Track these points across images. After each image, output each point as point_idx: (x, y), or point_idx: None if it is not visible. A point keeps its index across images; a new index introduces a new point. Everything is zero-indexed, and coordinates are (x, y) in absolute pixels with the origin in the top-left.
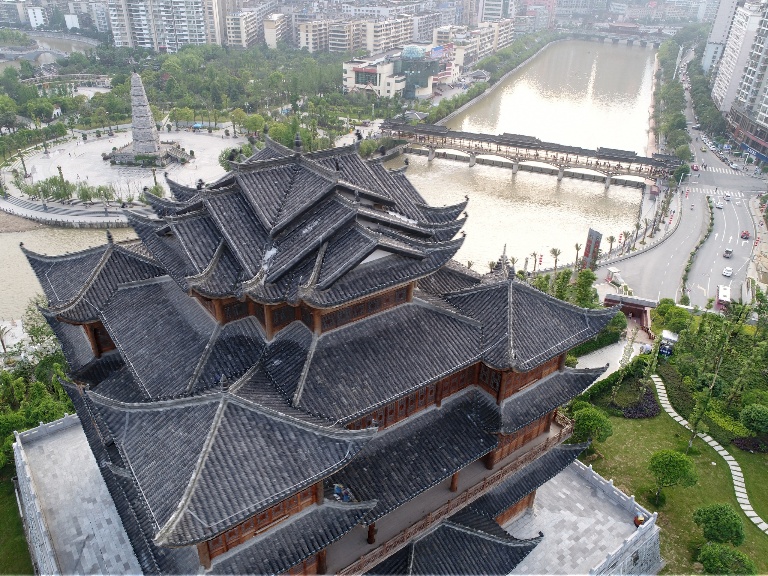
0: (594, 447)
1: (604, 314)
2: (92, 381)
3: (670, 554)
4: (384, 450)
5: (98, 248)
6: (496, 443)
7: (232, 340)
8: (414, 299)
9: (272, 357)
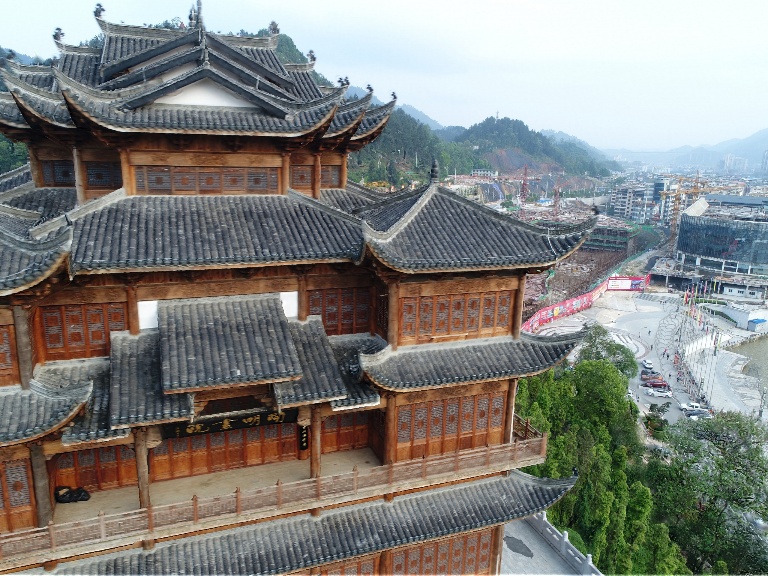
0: None
1: None
2: None
3: None
4: None
5: None
6: None
7: None
8: None
9: None
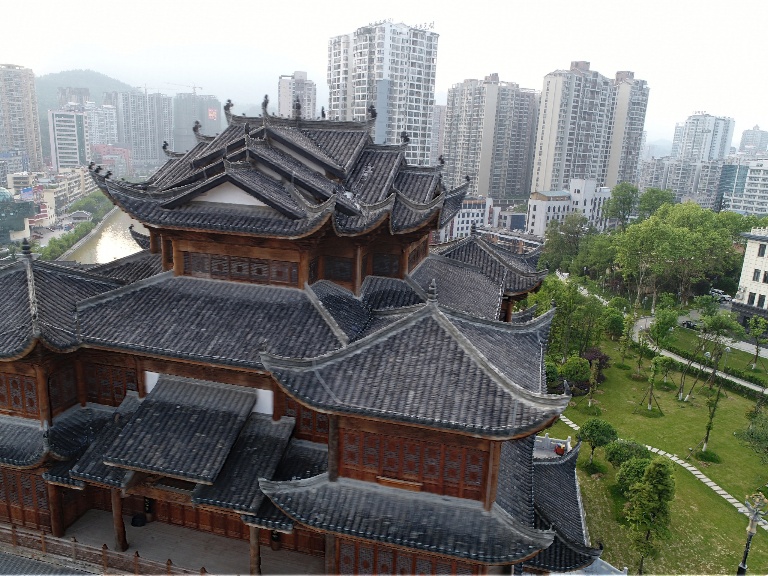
0: None
1: (533, 255)
2: (68, 452)
3: None
4: None
5: (2, 271)
6: None
7: (329, 299)
8: (430, 253)
9: (379, 306)
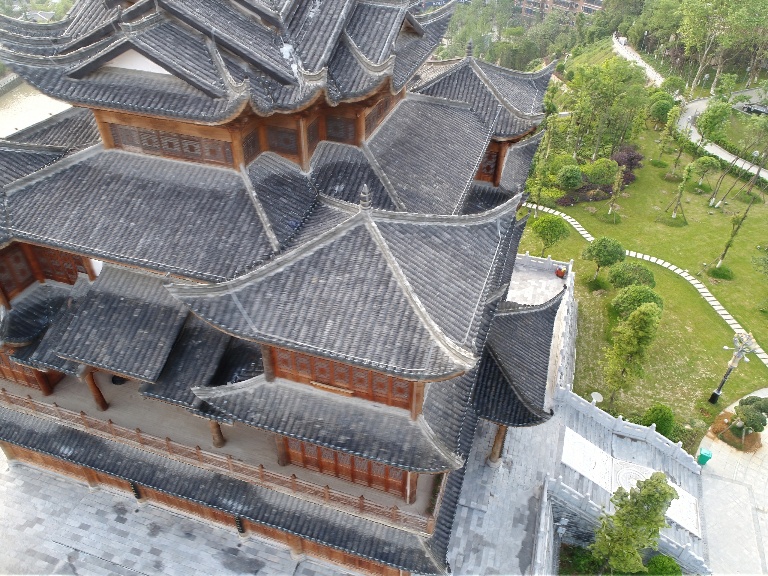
0: None
1: (544, 74)
2: (27, 338)
3: (576, 294)
4: None
5: None
6: None
7: (269, 182)
8: (407, 93)
9: (327, 185)
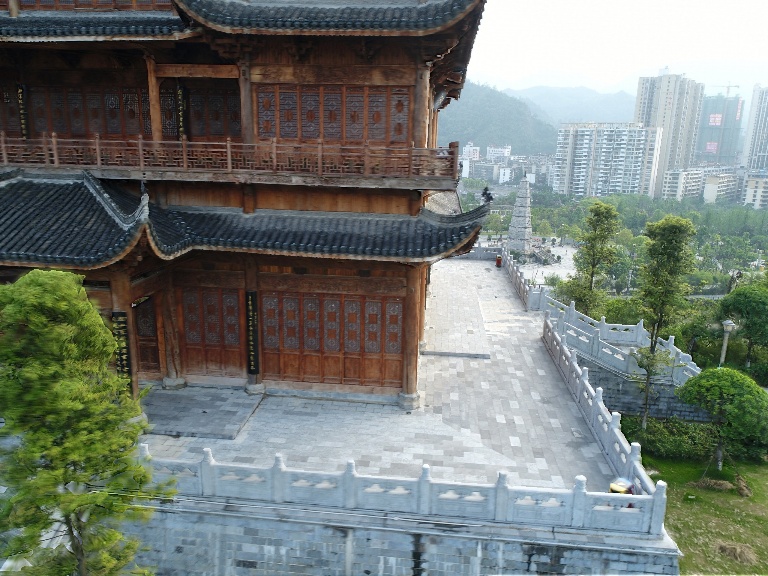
0: (739, 475)
1: None
2: None
3: None
4: (43, 21)
5: None
6: (172, 27)
7: None
8: None
9: None
